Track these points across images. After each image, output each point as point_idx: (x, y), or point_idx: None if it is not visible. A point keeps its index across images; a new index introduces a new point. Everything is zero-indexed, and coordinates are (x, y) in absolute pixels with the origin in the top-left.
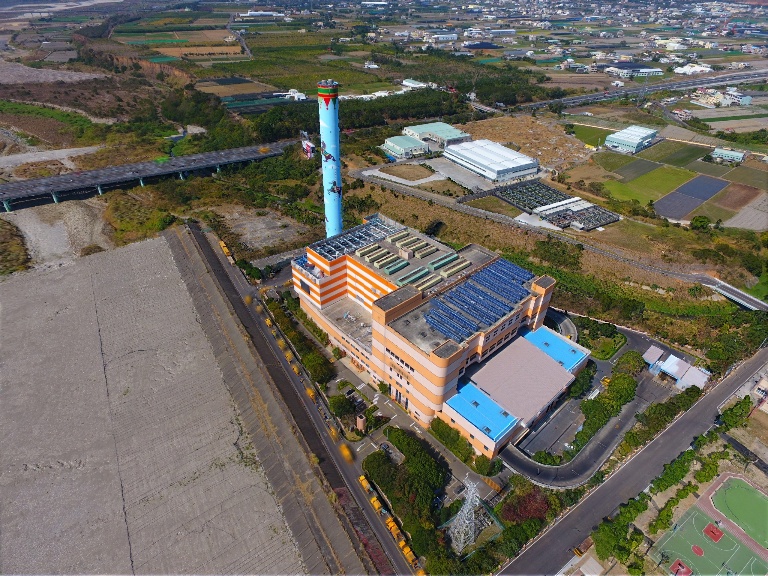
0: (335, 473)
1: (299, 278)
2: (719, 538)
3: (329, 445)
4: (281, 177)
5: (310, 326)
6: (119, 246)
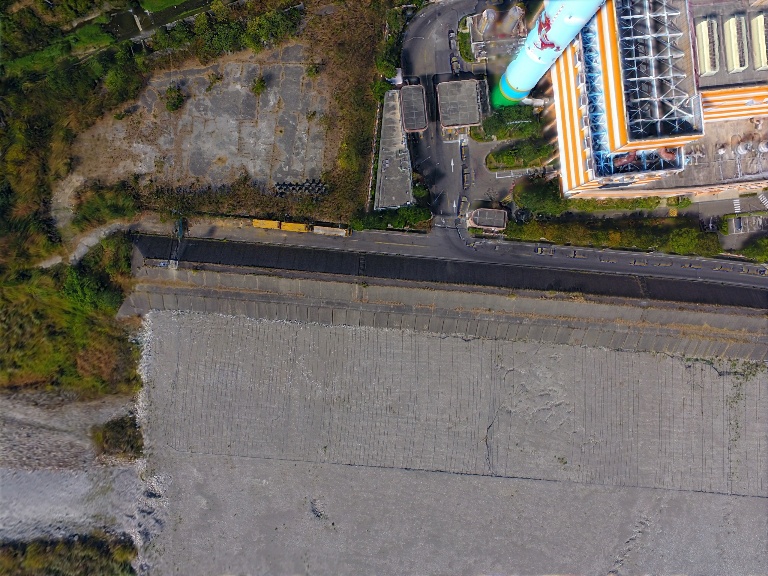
0: None
1: None
2: None
3: None
4: None
5: None
6: (135, 392)
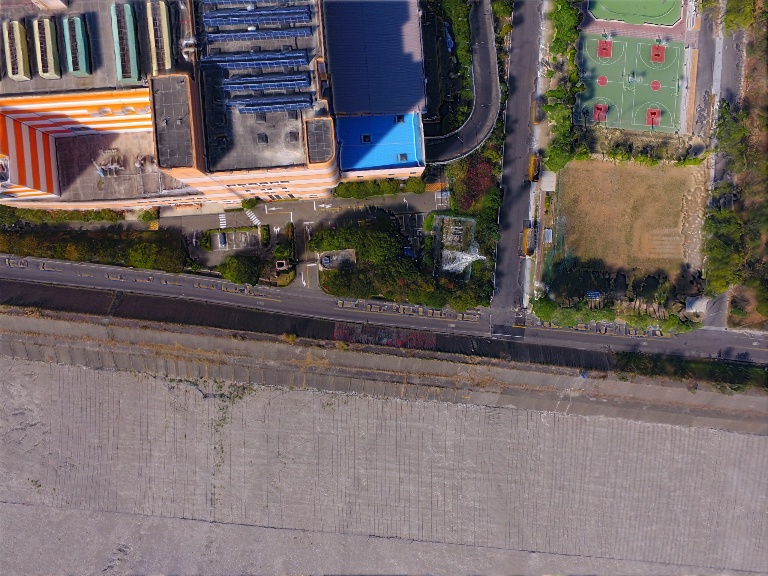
0: (315, 324)
1: None
2: (611, 51)
3: (277, 308)
4: None
5: (66, 213)
6: None
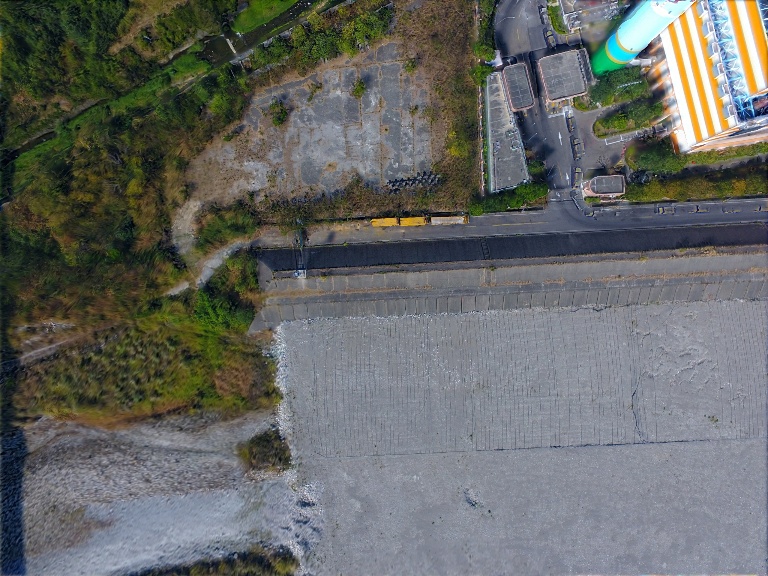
0: None
1: None
2: None
3: None
4: (119, 9)
5: None
6: (276, 405)
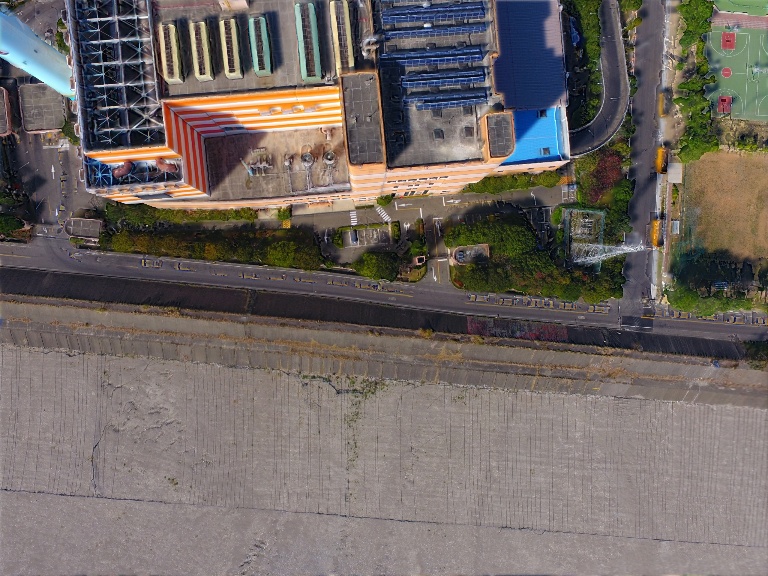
0: (448, 318)
1: (129, 196)
2: (735, 42)
3: (409, 303)
4: None
5: None
6: None
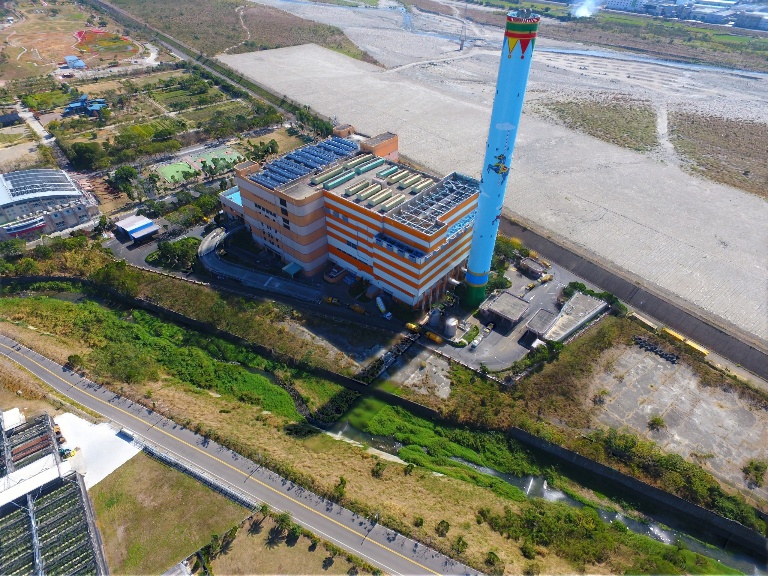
0: None
1: None
2: None
3: None
4: None
5: None
6: None
